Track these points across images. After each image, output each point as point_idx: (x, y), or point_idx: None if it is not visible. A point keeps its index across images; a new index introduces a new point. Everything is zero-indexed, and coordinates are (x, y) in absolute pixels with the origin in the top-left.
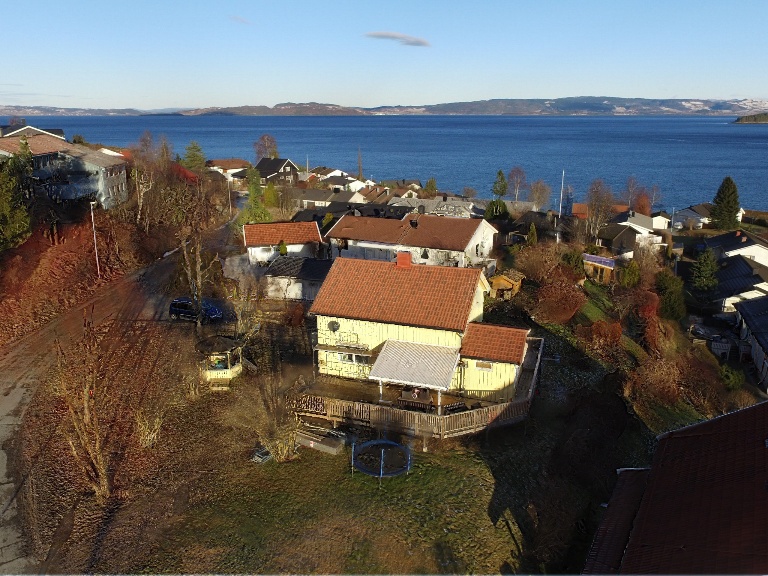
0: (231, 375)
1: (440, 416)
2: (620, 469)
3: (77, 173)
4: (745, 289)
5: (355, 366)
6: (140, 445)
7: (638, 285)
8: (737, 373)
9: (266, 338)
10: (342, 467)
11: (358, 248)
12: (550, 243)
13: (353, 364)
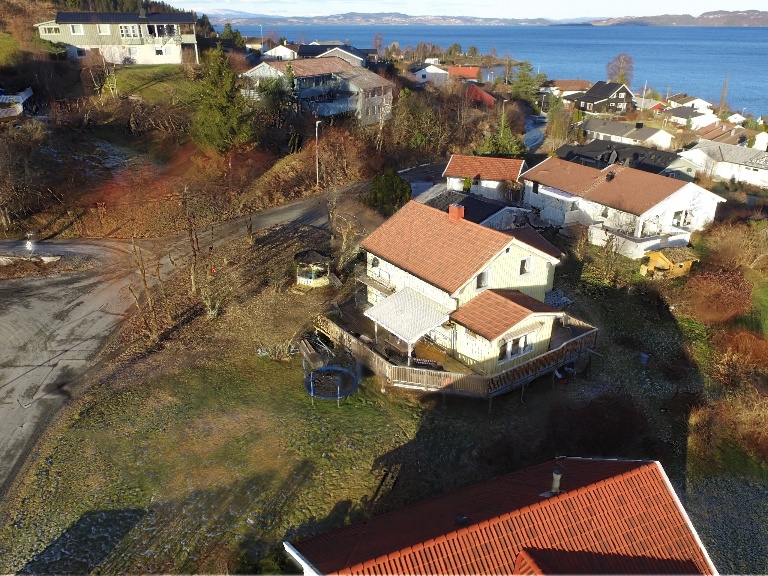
0: (315, 285)
1: (390, 364)
2: None
3: (344, 93)
4: None
5: None
6: (207, 316)
7: None
8: None
9: None
10: None
11: None
12: None
13: None
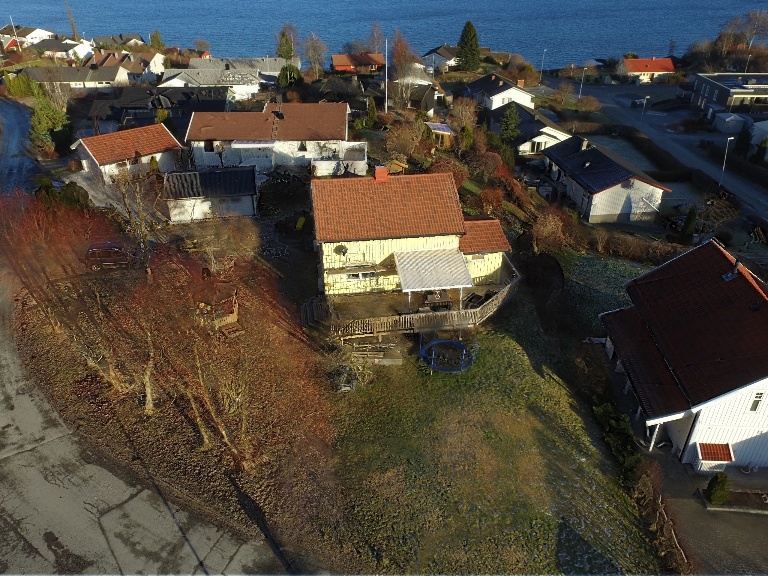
0: (236, 318)
1: (476, 309)
2: (601, 314)
3: None
4: (535, 134)
5: (362, 281)
6: (227, 411)
7: (475, 146)
8: (573, 211)
9: (222, 270)
10: (415, 373)
11: (229, 149)
12: (381, 113)
13: (360, 280)
